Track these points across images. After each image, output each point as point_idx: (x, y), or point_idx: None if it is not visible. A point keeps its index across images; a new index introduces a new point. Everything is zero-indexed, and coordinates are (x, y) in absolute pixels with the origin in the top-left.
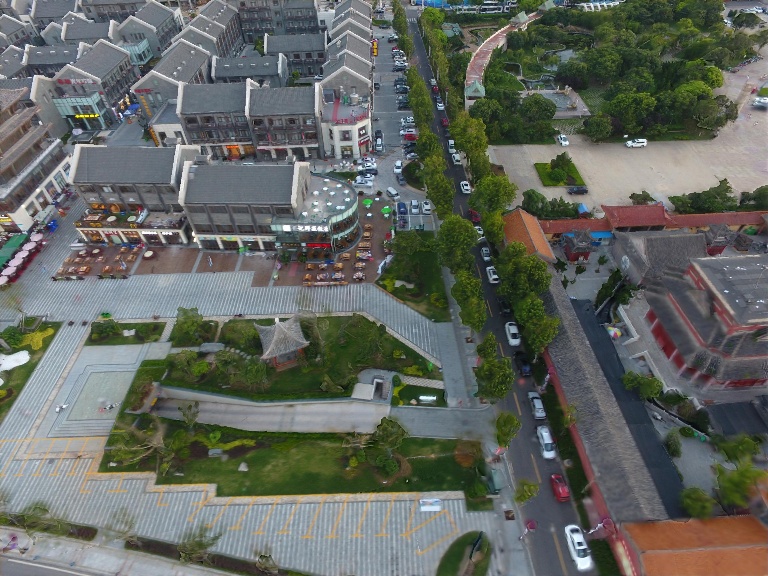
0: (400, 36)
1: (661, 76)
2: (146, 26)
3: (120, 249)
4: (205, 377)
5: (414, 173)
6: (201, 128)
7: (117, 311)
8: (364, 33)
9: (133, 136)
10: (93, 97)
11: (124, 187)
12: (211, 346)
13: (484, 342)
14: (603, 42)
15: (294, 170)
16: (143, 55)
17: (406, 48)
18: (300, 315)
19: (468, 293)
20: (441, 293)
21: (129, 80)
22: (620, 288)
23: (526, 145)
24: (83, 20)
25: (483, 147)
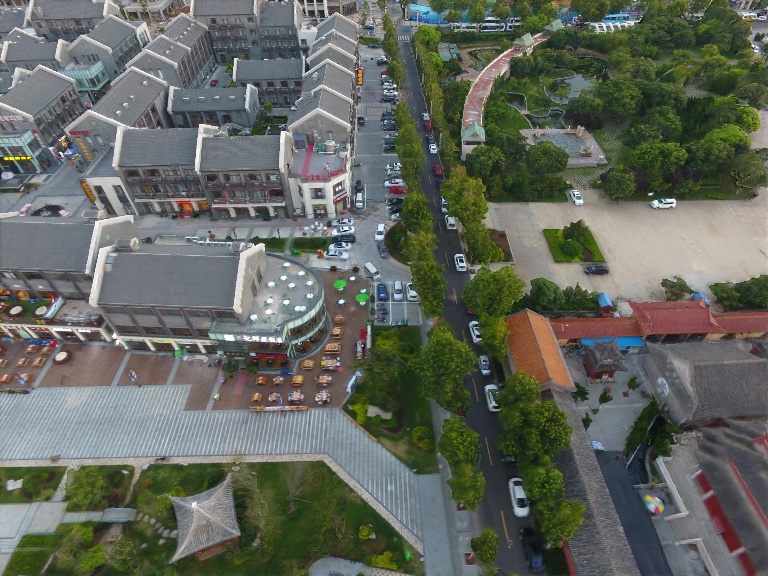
0: (389, 62)
1: (686, 113)
2: (100, 47)
3: (27, 347)
4: (102, 567)
5: (399, 241)
6: (144, 182)
7: (6, 446)
8: (347, 60)
9: (72, 182)
10: (23, 137)
11: (29, 273)
12: (118, 512)
13: (481, 540)
14: (619, 71)
15: (239, 264)
16: (96, 80)
17: (396, 76)
18: (233, 482)
19: (460, 457)
20: (426, 431)
21: (74, 112)
22: (657, 424)
23: (533, 203)
24: (31, 37)
25: (482, 213)
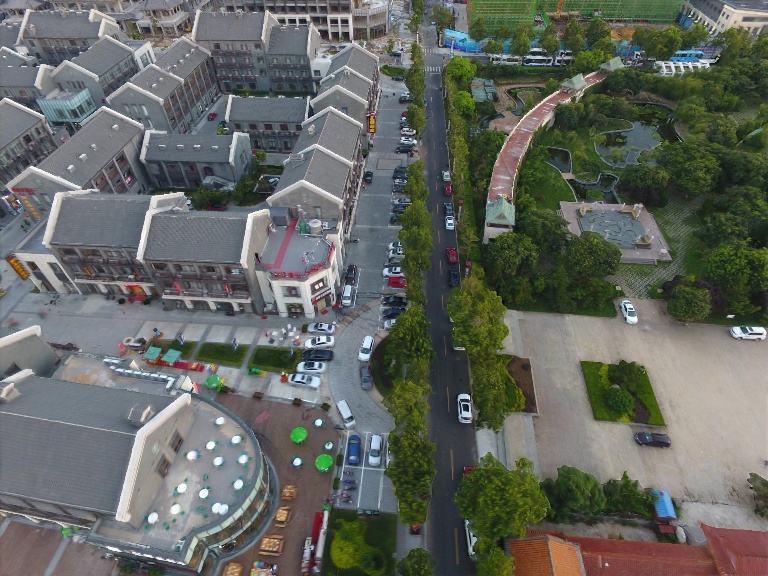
0: None
1: None
2: (85, 73)
3: None
4: None
5: (388, 365)
6: (83, 262)
7: None
8: (357, 104)
9: None
10: None
11: None
12: None
13: None
14: (690, 130)
15: (132, 450)
16: (79, 110)
17: (415, 124)
18: None
19: None
20: None
21: (42, 152)
22: None
23: (570, 316)
24: (19, 57)
25: None
